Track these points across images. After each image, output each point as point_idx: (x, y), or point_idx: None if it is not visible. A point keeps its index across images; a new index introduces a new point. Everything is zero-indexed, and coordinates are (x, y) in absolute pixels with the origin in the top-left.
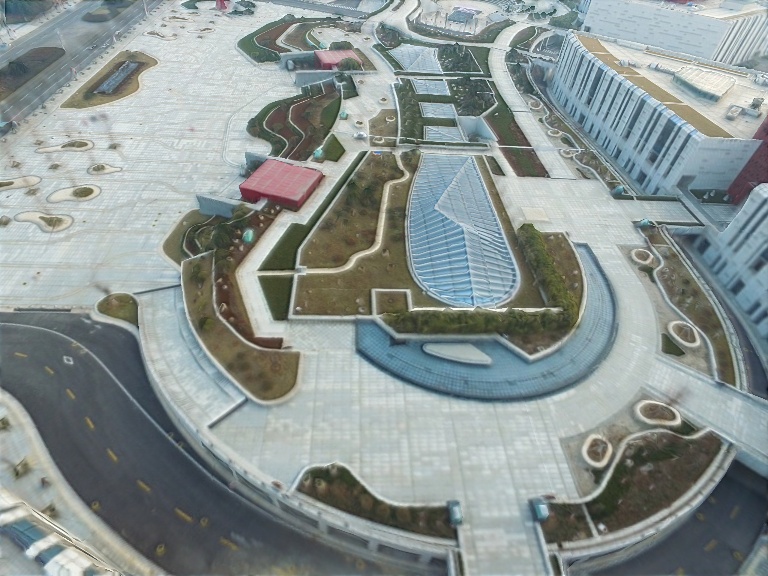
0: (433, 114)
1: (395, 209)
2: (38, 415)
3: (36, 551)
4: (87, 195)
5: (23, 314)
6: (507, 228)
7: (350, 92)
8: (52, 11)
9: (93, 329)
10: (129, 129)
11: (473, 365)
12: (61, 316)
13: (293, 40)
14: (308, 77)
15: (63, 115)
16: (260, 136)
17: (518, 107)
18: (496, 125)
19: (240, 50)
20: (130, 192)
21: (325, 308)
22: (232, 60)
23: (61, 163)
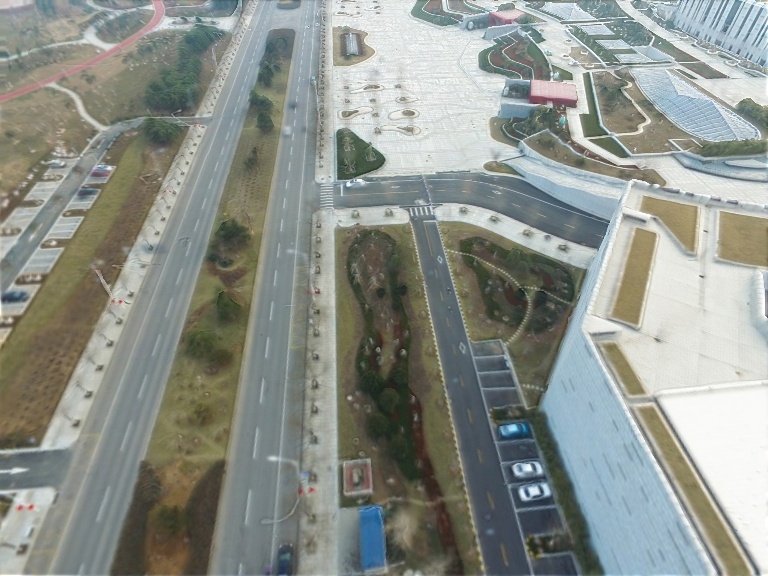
0: (613, 47)
1: (642, 101)
2: (509, 214)
3: (684, 192)
4: (413, 114)
5: (444, 175)
6: (727, 106)
7: (538, 38)
8: (251, 4)
9: (494, 178)
10: (397, 75)
11: (762, 169)
12: (467, 174)
13: (457, 8)
14: (497, 31)
15: (342, 71)
16: (496, 72)
17: (670, 38)
18: (665, 50)
19: (419, 19)
20: (438, 111)
21: (648, 150)
22: (419, 27)
23: (375, 98)
